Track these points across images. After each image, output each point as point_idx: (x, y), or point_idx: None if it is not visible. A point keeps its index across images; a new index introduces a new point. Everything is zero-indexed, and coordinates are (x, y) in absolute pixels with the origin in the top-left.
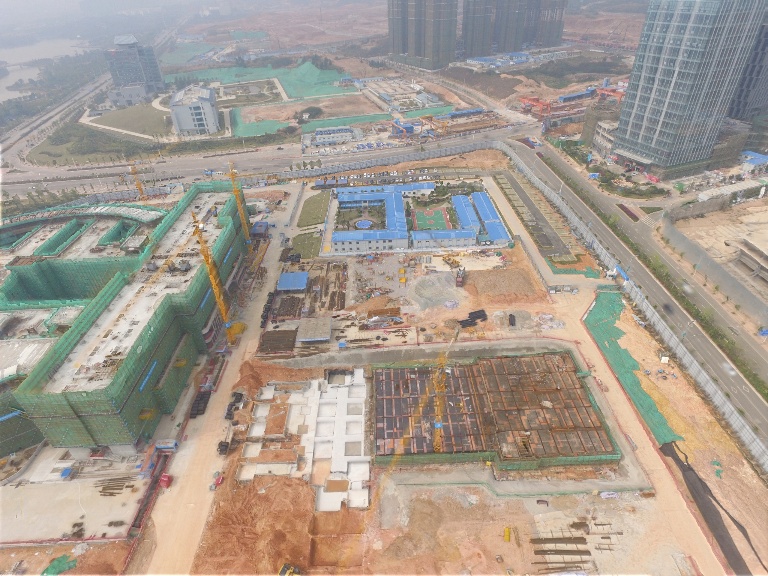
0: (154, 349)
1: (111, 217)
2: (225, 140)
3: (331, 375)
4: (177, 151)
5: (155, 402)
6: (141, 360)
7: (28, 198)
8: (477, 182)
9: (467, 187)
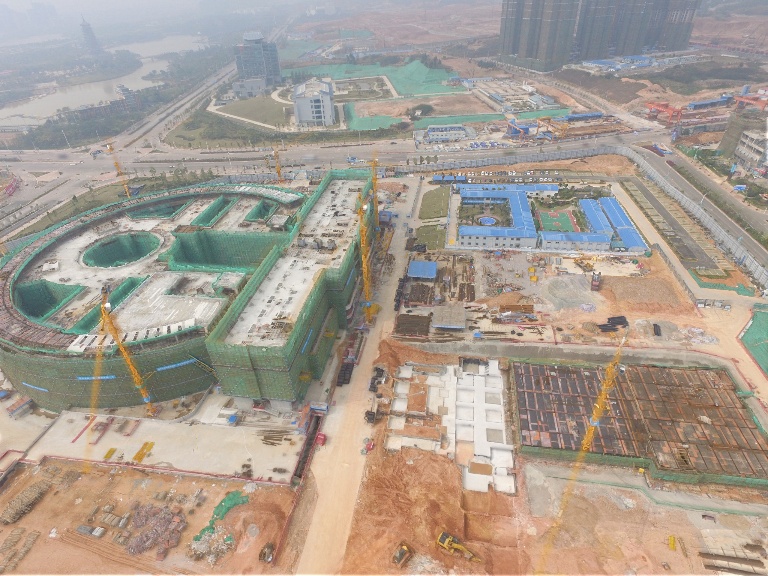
0: (312, 318)
1: (253, 196)
2: (341, 132)
3: (465, 363)
4: (297, 141)
5: (308, 366)
6: (304, 326)
7: (173, 175)
8: (605, 187)
9: (593, 191)
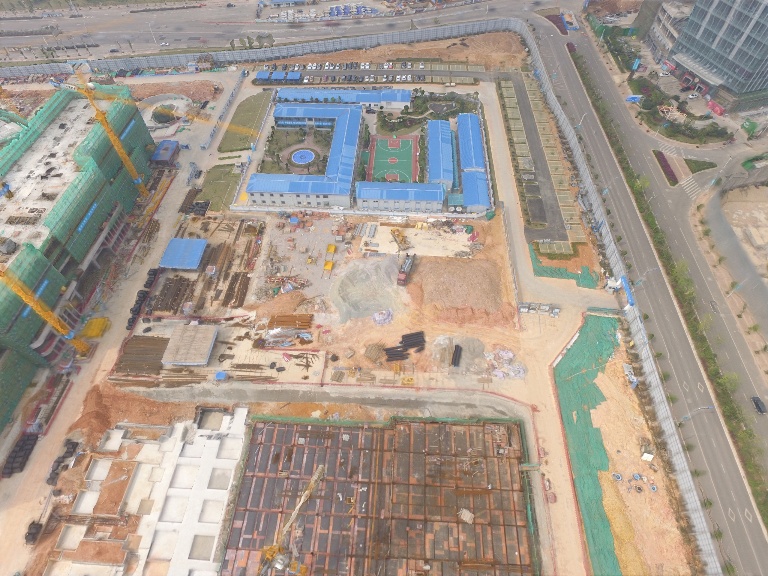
0: None
1: None
2: None
3: (206, 412)
4: None
5: None
6: None
7: None
8: (470, 95)
9: (457, 101)
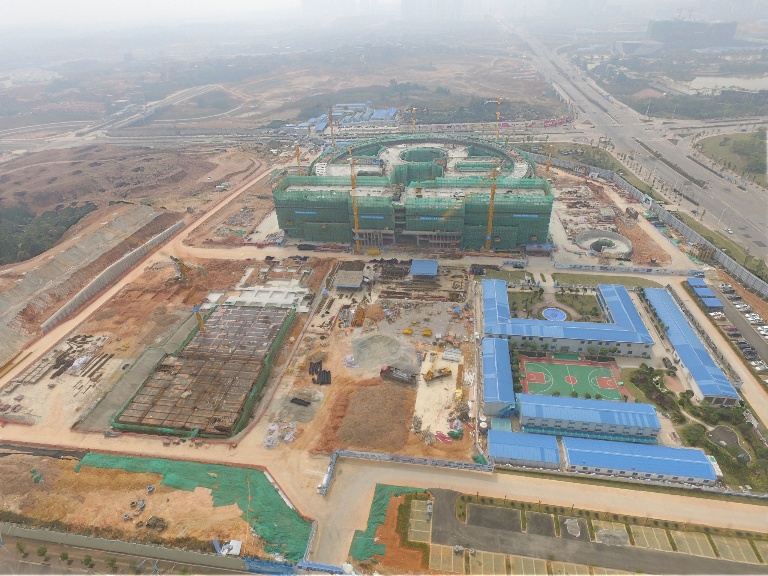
0: (319, 207)
1: None
2: None
3: None
4: None
5: None
6: (305, 202)
7: None
8: None
9: (759, 461)
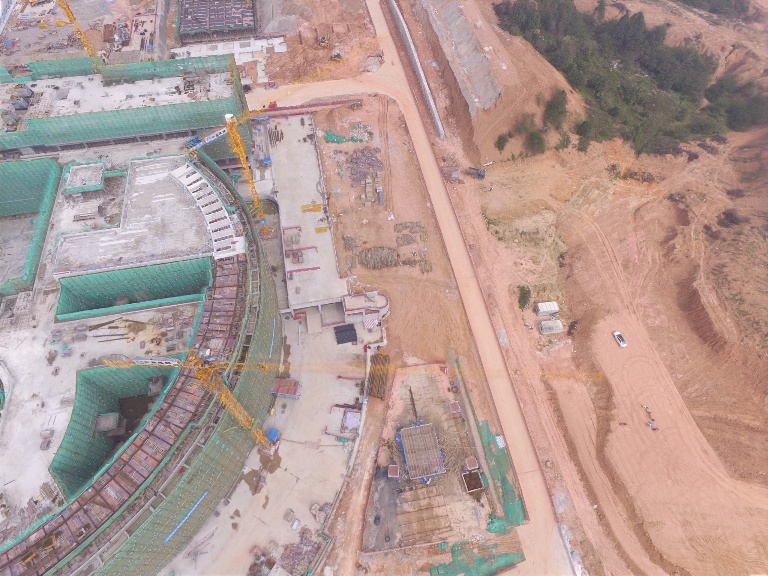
0: None
1: None
2: None
3: None
4: None
5: None
6: None
7: None
8: None
9: None
